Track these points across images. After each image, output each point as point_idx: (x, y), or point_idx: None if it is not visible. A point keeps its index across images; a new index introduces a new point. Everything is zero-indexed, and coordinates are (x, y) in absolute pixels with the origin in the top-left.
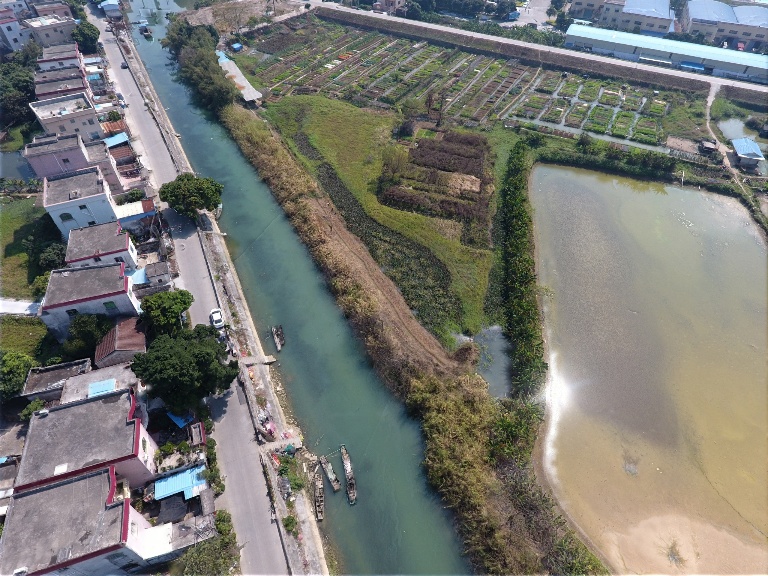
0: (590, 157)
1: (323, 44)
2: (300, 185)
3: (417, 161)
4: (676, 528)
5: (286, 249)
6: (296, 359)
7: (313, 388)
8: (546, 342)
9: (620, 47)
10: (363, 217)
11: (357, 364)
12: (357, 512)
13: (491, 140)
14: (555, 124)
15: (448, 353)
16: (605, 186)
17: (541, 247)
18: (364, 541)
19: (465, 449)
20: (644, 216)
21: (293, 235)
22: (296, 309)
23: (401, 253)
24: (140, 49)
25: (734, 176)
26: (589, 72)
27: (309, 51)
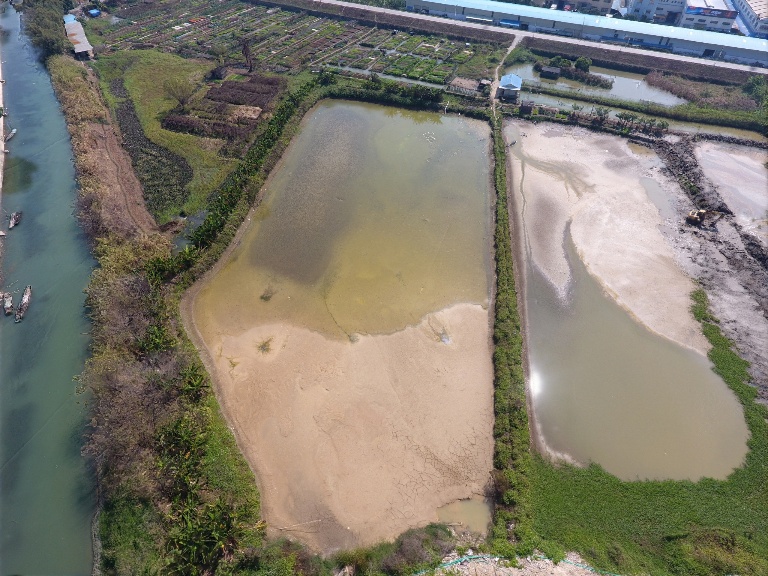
0: (370, 92)
1: (180, 10)
2: (88, 113)
3: (213, 97)
4: (278, 331)
5: (57, 161)
6: (23, 234)
7: (27, 252)
8: (250, 220)
9: (450, 8)
10: (140, 138)
11: (74, 236)
12: (19, 327)
13: (293, 82)
14: (362, 70)
15: (155, 227)
16: (377, 114)
17: (289, 157)
18: (14, 343)
19: (109, 275)
20: (397, 135)
21: (69, 151)
22: (42, 201)
23: (160, 163)
24: (3, 16)
25: (492, 104)
26: (415, 29)
27: (164, 16)
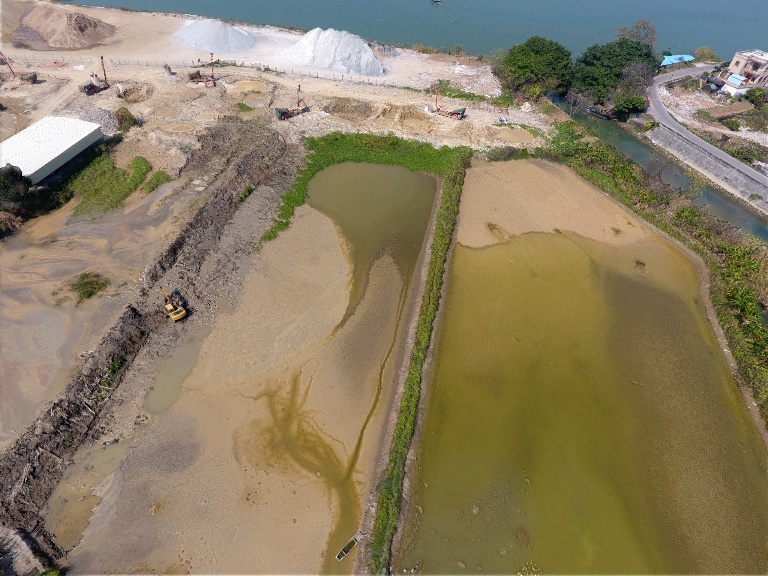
0: None
1: None
2: None
3: None
4: (614, 239)
5: None
6: None
7: None
8: (724, 350)
9: None
10: None
11: None
12: None
13: None
14: None
15: None
16: None
17: None
18: None
19: None
20: None
21: None
22: None
23: None
24: None
25: None
26: None
27: None
